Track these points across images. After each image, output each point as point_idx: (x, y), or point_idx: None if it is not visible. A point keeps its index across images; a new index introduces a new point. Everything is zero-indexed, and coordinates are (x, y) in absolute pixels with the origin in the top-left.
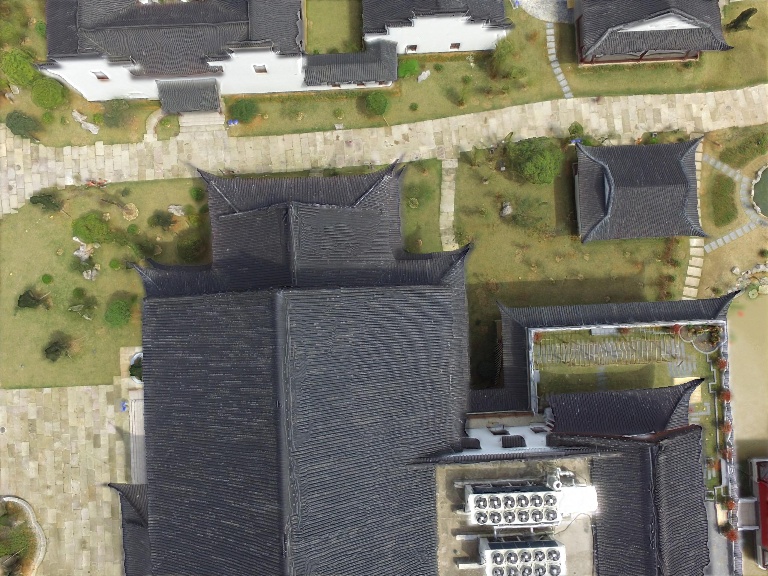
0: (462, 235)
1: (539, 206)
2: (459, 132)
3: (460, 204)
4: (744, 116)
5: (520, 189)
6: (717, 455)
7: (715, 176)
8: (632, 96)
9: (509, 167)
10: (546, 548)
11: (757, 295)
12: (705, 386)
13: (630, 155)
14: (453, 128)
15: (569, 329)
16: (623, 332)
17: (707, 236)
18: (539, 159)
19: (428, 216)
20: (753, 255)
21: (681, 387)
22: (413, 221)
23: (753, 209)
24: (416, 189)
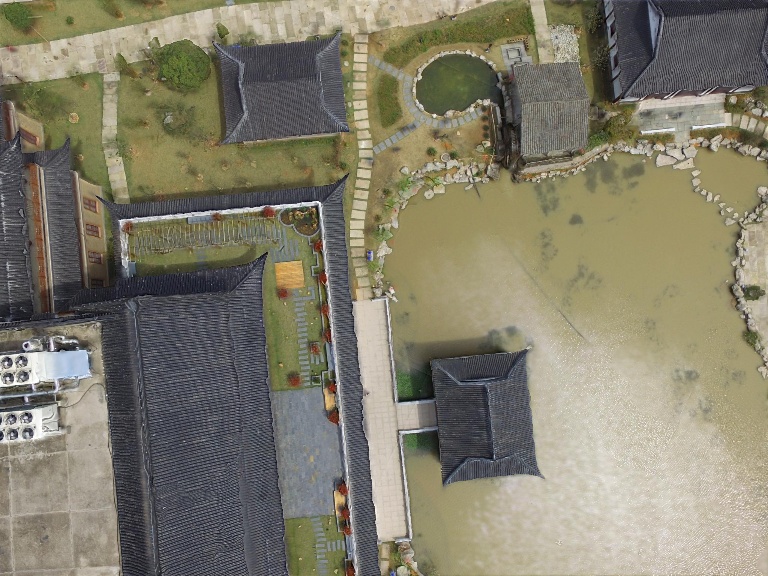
0: (125, 148)
1: (204, 115)
2: (120, 44)
3: (123, 117)
4: (408, 15)
5: (184, 99)
6: (323, 339)
7: (380, 76)
8: (294, 0)
9: (159, 74)
10: (20, 412)
11: (433, 195)
12: (308, 270)
13: (269, 53)
14: (113, 41)
15: (164, 219)
16: (221, 219)
17: (375, 137)
18: (174, 60)
19: (89, 130)
20: (421, 154)
21: (251, 264)
22: (73, 136)
23: (416, 107)
24: (76, 104)
